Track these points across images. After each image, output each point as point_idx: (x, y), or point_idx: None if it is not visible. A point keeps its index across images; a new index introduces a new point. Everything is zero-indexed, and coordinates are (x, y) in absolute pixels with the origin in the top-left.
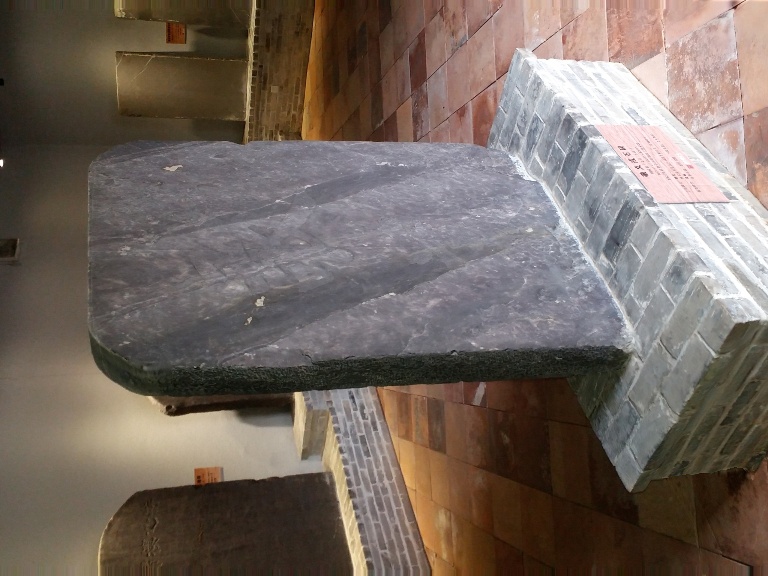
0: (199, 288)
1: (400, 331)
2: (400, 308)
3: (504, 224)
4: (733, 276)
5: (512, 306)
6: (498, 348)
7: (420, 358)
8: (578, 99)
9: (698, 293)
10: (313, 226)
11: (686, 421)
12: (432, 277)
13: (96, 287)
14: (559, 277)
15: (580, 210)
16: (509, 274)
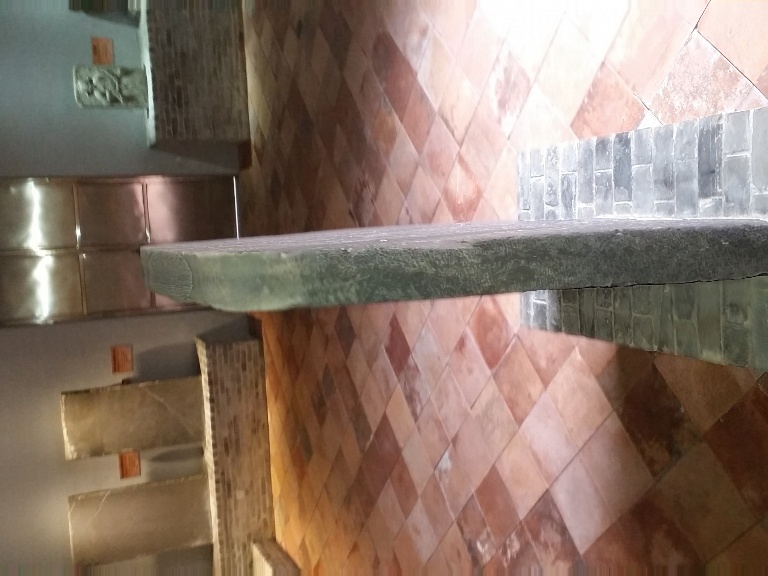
0: None
1: None
2: None
3: None
4: None
5: None
6: (660, 227)
7: (585, 239)
8: None
9: None
10: (401, 233)
11: None
12: None
13: None
14: None
15: (653, 194)
16: None
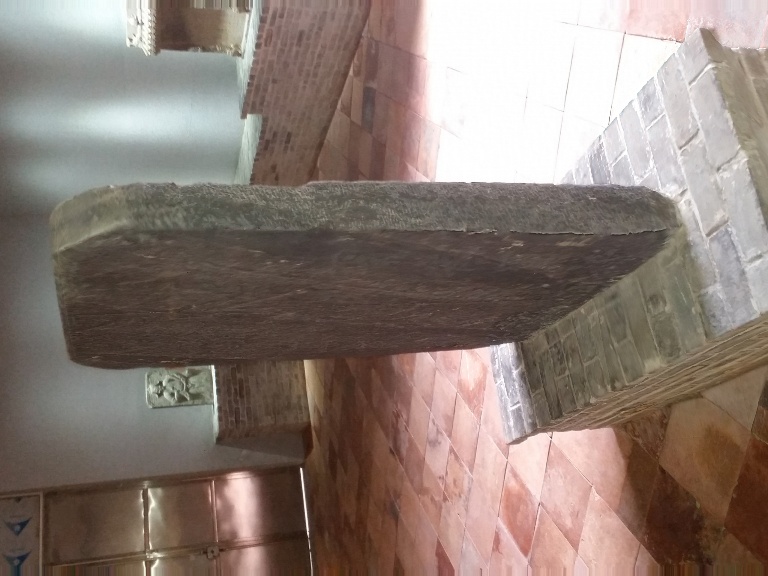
0: None
1: None
2: None
3: None
4: None
5: None
6: None
7: (429, 187)
8: None
9: (666, 73)
10: None
11: (759, 161)
12: None
13: None
14: None
15: None
16: None
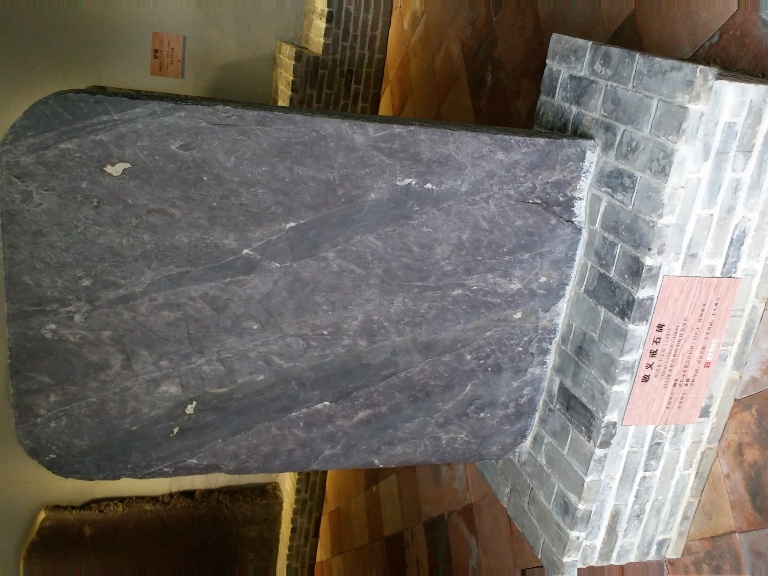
0: (130, 389)
1: (316, 447)
2: (327, 421)
3: (496, 303)
4: (607, 523)
5: (436, 420)
6: None
7: None
8: (692, 208)
9: (561, 540)
10: (276, 299)
11: None
12: (376, 382)
13: (19, 386)
14: (504, 385)
15: (579, 326)
16: (457, 379)
